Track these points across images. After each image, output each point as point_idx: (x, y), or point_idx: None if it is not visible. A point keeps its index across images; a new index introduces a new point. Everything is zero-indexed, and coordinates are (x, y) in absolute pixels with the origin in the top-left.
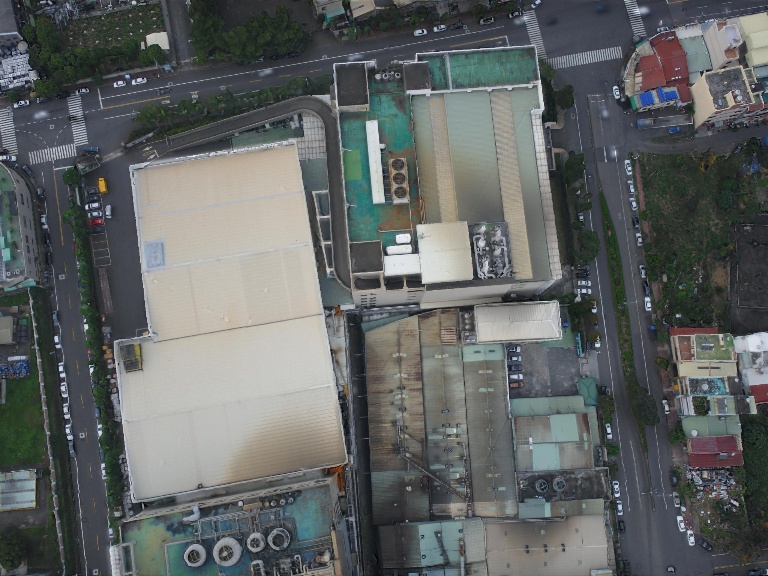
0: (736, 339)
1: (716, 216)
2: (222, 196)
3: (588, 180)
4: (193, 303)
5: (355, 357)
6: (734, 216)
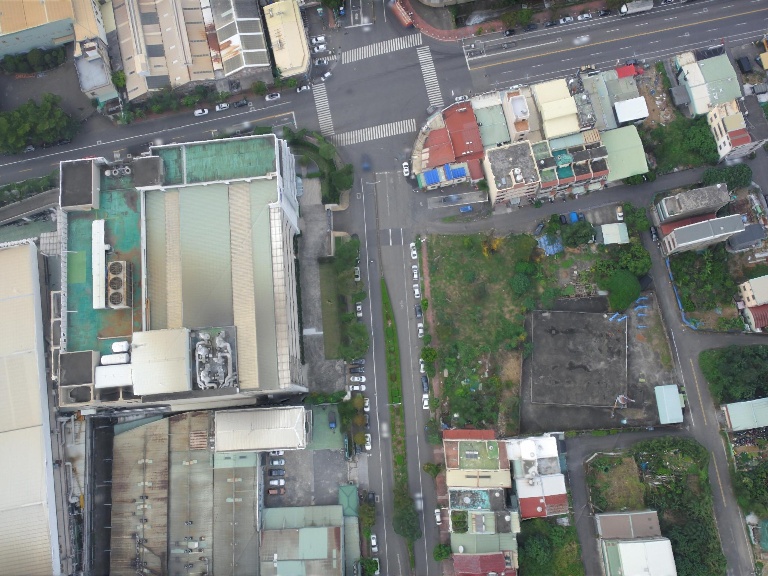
0: (512, 444)
1: (511, 302)
2: None
3: (370, 265)
4: None
5: (104, 462)
6: (527, 303)
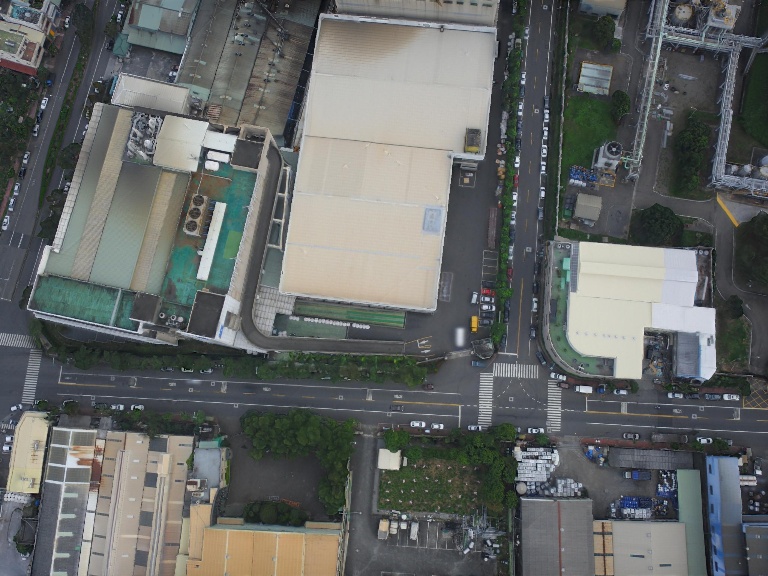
0: None
1: None
2: (360, 260)
3: None
4: (411, 172)
5: None
6: None
